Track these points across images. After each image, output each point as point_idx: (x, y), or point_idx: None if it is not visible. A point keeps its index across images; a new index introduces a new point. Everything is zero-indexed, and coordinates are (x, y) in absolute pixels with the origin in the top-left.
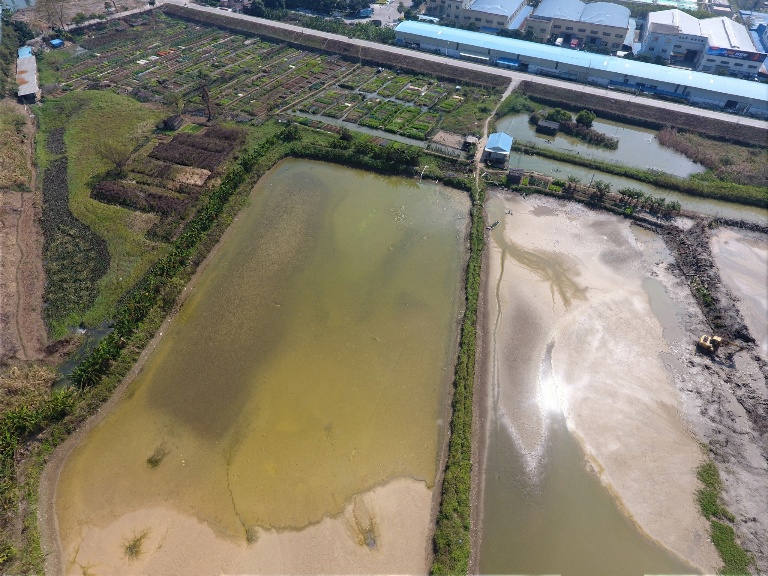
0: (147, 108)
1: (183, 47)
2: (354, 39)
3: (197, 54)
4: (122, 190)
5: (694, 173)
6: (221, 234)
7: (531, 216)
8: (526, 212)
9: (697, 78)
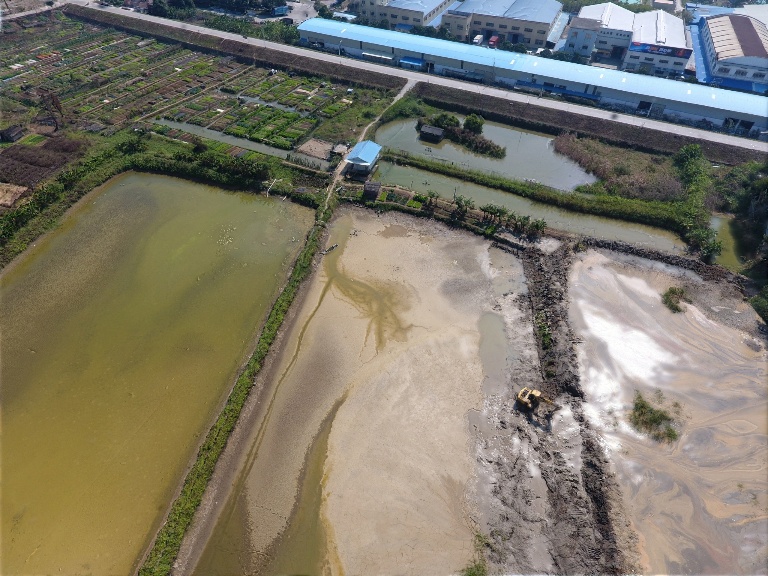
0: None
1: (69, 50)
2: (252, 39)
3: (80, 57)
4: None
5: (582, 185)
6: (4, 264)
7: (378, 237)
8: (374, 233)
9: (608, 77)
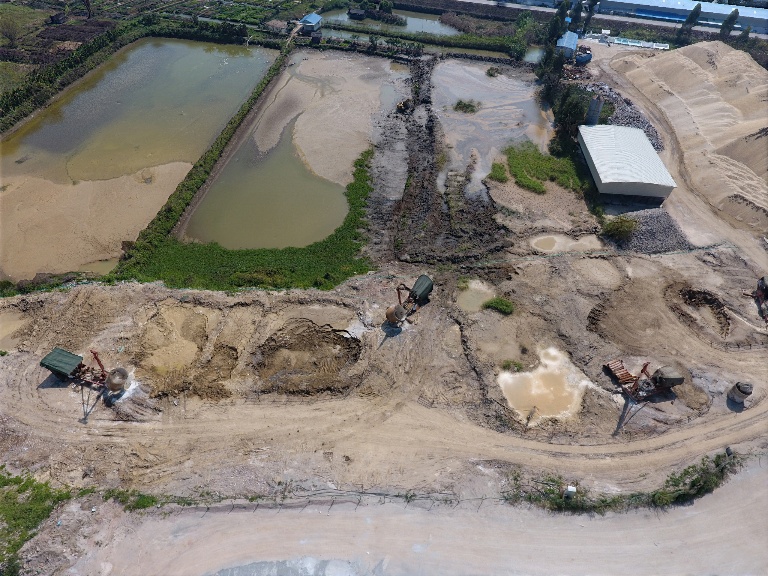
0: (39, 12)
1: None
2: None
3: None
4: (11, 51)
5: None
6: (85, 72)
7: (321, 60)
8: (319, 58)
9: None
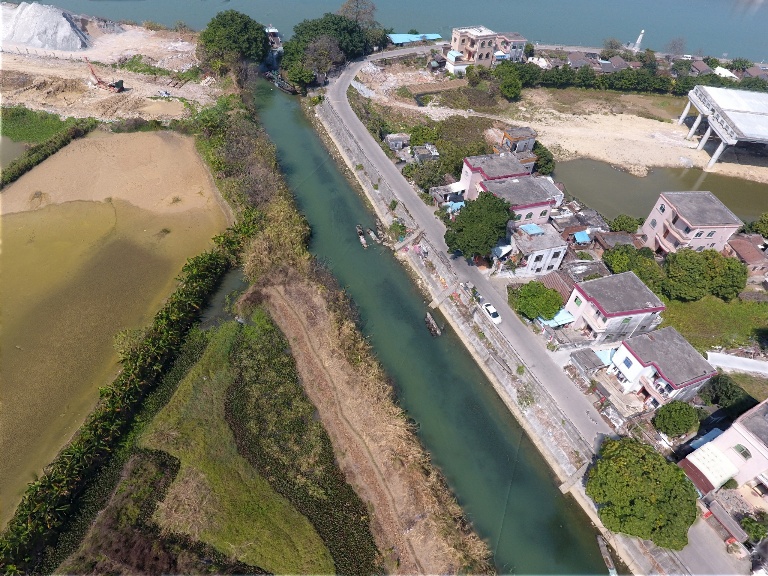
0: None
1: None
2: None
3: None
4: None
5: None
6: None
7: None
8: None
9: None
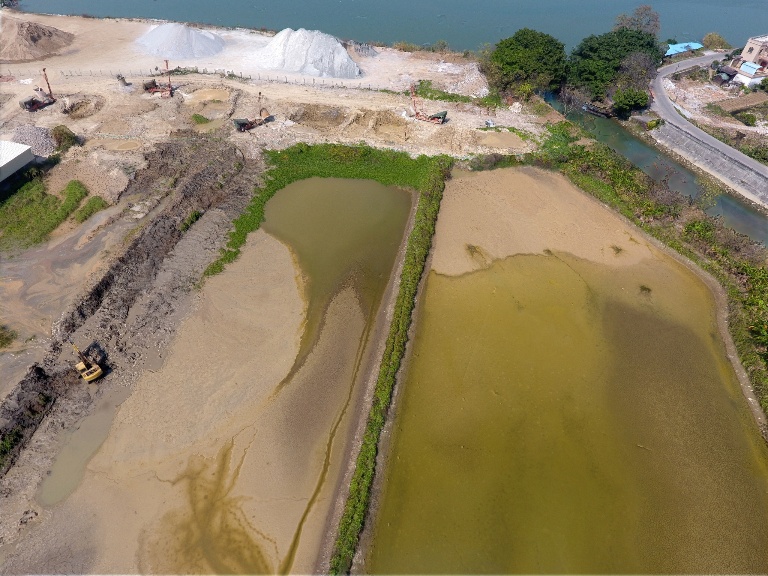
0: None
1: None
2: None
3: None
4: None
5: None
6: None
7: None
8: None
9: None
